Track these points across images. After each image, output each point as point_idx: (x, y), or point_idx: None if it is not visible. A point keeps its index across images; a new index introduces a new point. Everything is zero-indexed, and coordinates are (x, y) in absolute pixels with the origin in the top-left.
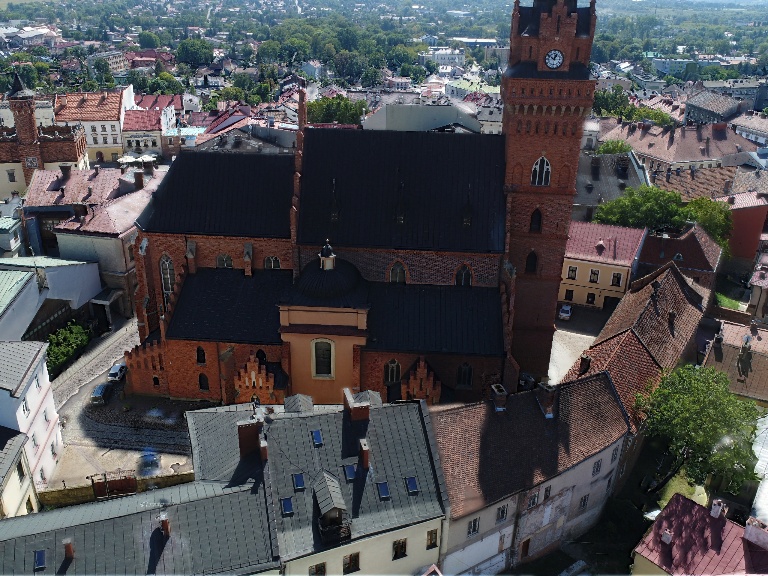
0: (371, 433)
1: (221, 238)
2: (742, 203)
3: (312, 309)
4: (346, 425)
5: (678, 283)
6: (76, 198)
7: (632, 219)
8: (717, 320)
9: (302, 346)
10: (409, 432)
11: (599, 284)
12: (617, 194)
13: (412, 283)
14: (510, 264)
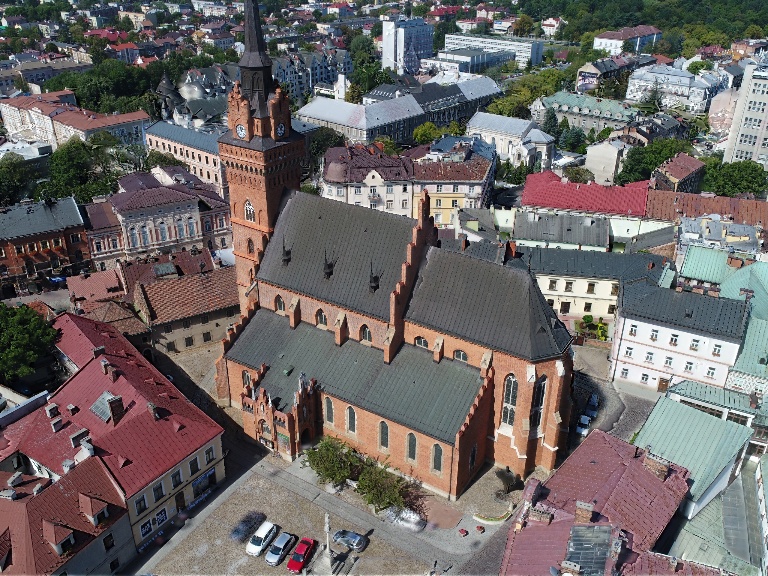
0: None
1: None
2: None
3: None
4: None
5: None
6: (697, 572)
7: None
8: None
9: None
10: None
11: None
12: None
13: None
14: None
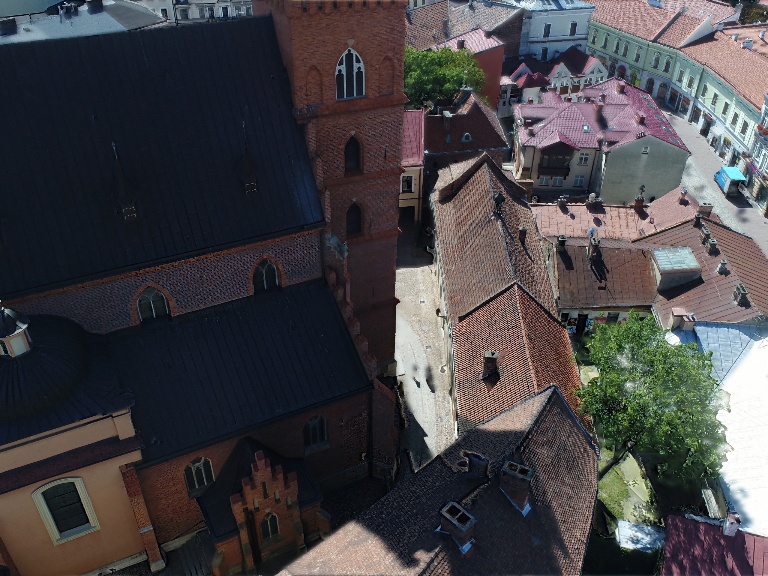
0: None
1: None
2: (474, 46)
3: (14, 443)
4: None
5: (498, 180)
6: None
7: None
8: None
9: (15, 508)
10: None
11: None
12: None
13: (182, 313)
14: (334, 237)
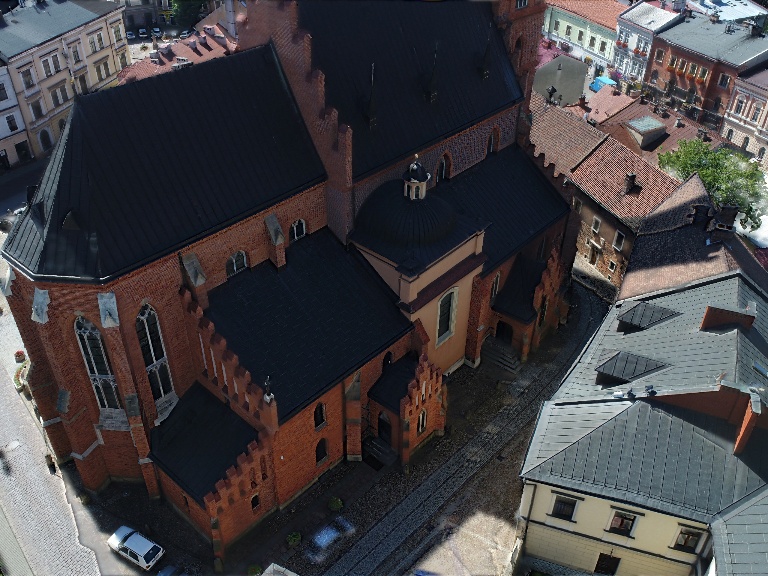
0: (761, 332)
1: (232, 227)
2: None
3: (438, 259)
4: (751, 339)
5: None
6: None
7: None
8: None
9: (429, 315)
10: (763, 309)
11: None
12: None
13: (454, 175)
14: None
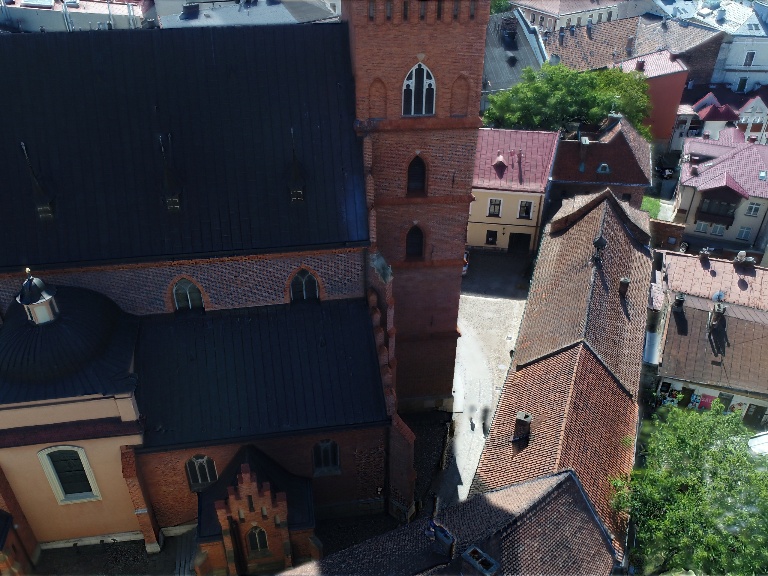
0: None
1: None
2: (654, 69)
3: (23, 403)
4: None
5: (618, 221)
6: None
7: (537, 117)
8: (657, 251)
9: (23, 462)
10: None
11: (502, 218)
12: (506, 73)
13: (215, 309)
14: (380, 259)
